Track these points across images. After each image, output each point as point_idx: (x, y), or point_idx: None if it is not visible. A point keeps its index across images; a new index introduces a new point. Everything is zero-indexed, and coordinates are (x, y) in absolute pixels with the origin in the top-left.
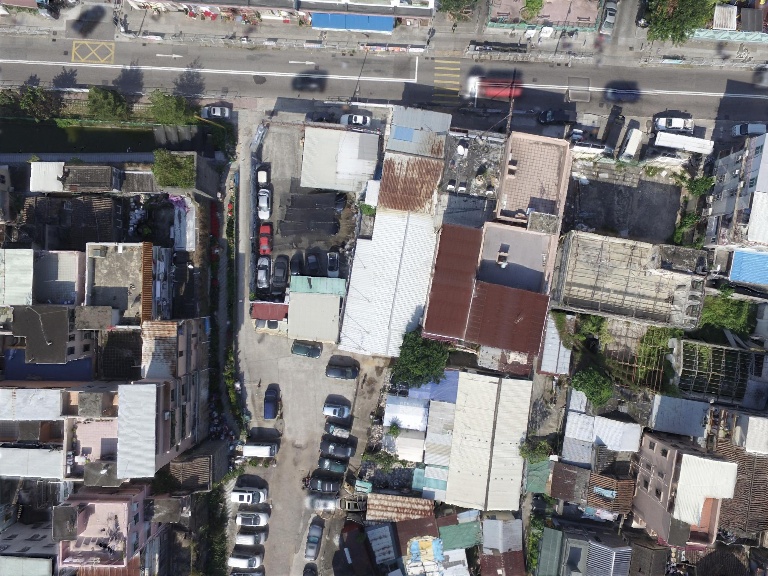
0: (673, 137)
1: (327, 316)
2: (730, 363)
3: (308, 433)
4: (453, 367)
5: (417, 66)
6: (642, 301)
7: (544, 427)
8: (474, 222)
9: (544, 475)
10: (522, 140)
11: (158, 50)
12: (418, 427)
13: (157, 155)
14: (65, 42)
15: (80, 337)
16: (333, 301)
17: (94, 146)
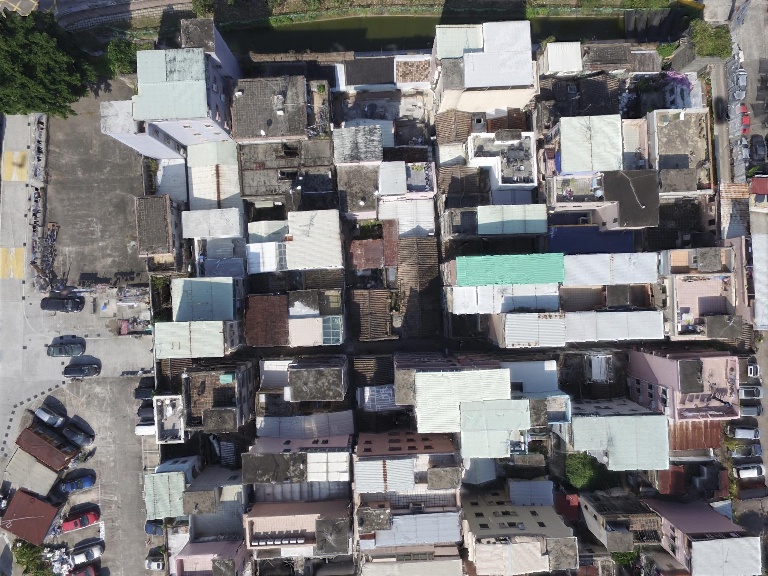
0: None
1: None
2: None
3: None
4: None
5: None
6: None
7: None
8: None
9: None
10: None
11: None
12: None
13: (697, 25)
14: None
15: None
16: None
17: (559, 36)
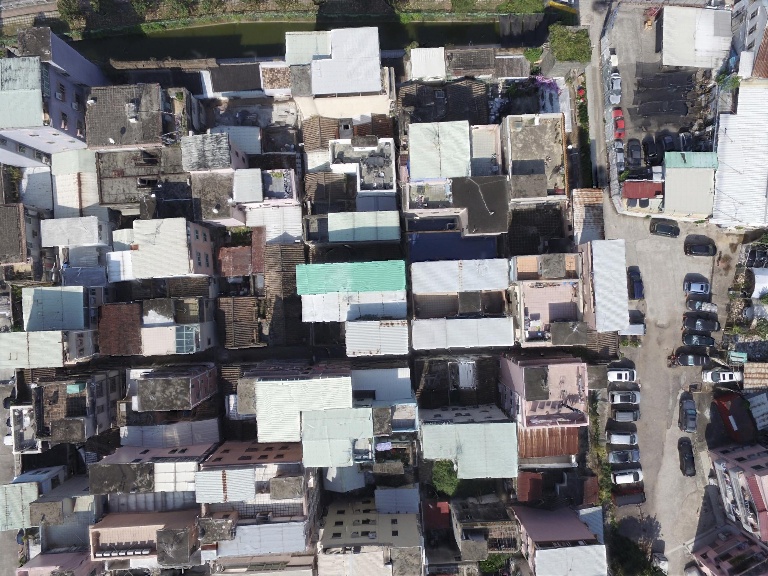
0: None
1: (703, 189)
2: None
3: (669, 312)
4: None
5: None
6: None
7: None
8: None
9: None
10: None
11: None
12: None
13: (555, 30)
14: None
15: None
16: (708, 174)
17: (435, 41)
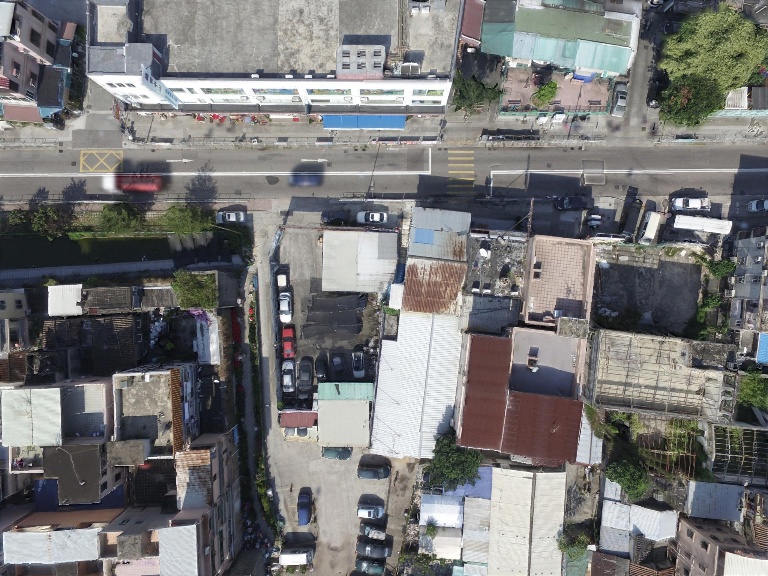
0: (691, 219)
1: (357, 422)
2: (762, 444)
3: (343, 535)
4: (486, 463)
5: (430, 158)
6: (673, 394)
7: (579, 514)
8: (500, 322)
9: (583, 565)
10: (545, 241)
11: (168, 155)
12: (454, 525)
13: (178, 277)
14: (72, 153)
15: (111, 469)
16: (362, 406)
17: (108, 256)
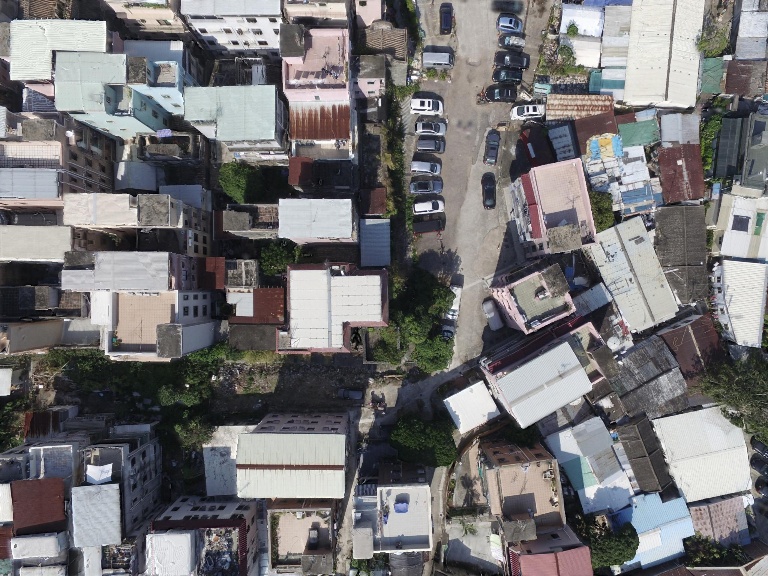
0: None
1: None
2: None
3: (481, 50)
4: None
5: None
6: None
7: None
8: None
9: (718, 76)
10: None
11: None
12: (594, 32)
13: None
14: None
15: None
16: None
17: None
